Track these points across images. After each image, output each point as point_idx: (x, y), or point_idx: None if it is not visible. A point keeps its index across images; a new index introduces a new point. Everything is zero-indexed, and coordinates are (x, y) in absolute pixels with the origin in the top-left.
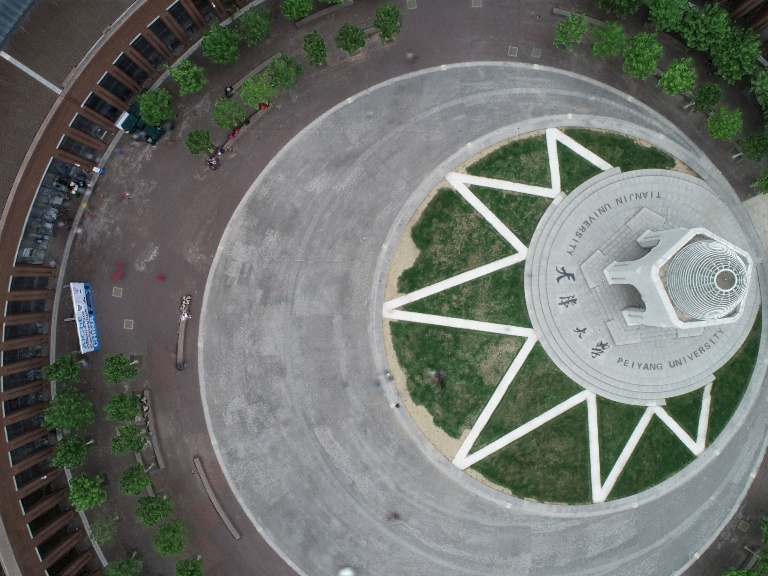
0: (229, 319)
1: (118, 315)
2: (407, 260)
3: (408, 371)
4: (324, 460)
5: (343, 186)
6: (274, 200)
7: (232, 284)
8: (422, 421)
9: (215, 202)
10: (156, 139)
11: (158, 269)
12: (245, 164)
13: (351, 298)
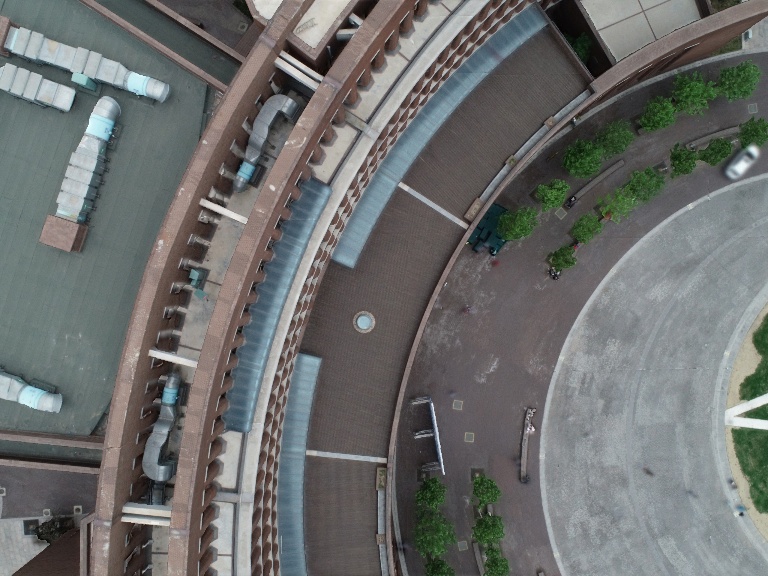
0: (570, 430)
1: (458, 428)
2: (749, 366)
3: (751, 479)
4: (668, 571)
5: (684, 293)
6: (615, 309)
7: (573, 394)
8: (766, 529)
9: (555, 312)
10: (498, 250)
11: (498, 381)
12: (585, 273)
13: (693, 406)
